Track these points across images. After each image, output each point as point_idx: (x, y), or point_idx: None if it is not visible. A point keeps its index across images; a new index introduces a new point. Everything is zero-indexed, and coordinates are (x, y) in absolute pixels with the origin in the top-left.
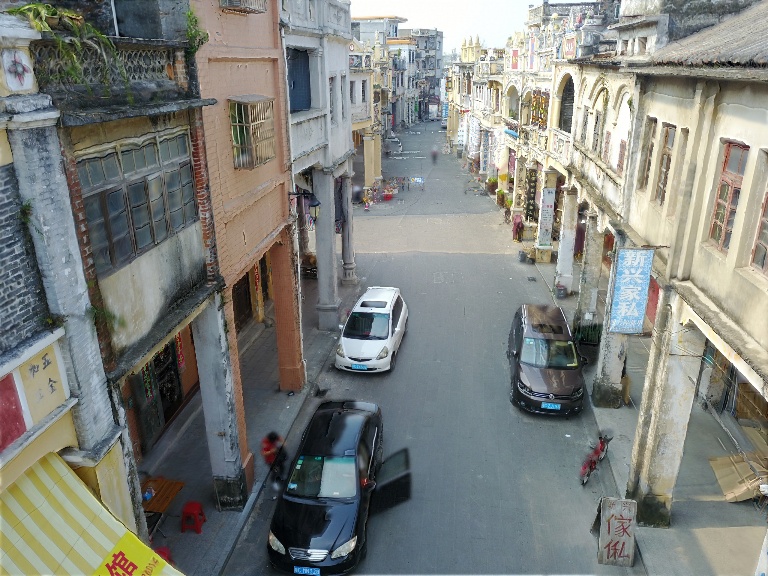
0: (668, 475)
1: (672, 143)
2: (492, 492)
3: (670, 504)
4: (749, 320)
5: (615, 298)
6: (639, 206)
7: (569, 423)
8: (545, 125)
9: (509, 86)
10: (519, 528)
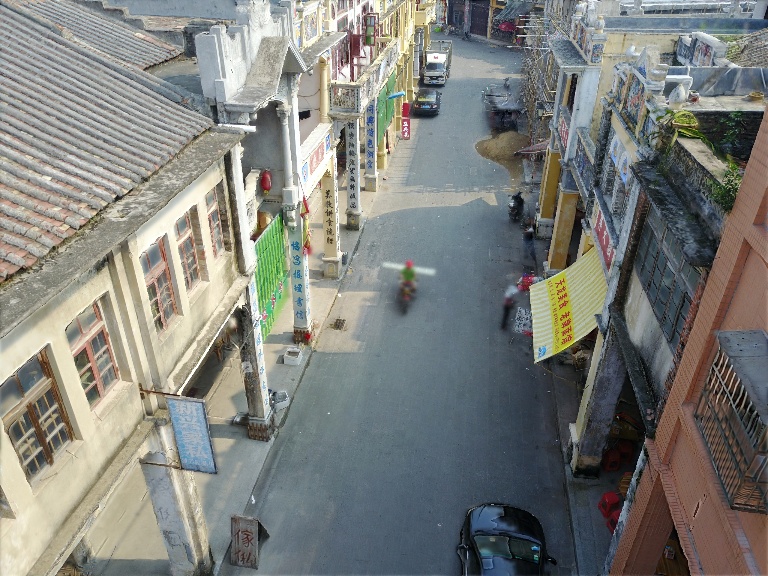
0: None
1: (22, 391)
2: None
3: None
4: None
5: None
6: (2, 558)
7: None
8: None
9: None
10: (322, 572)
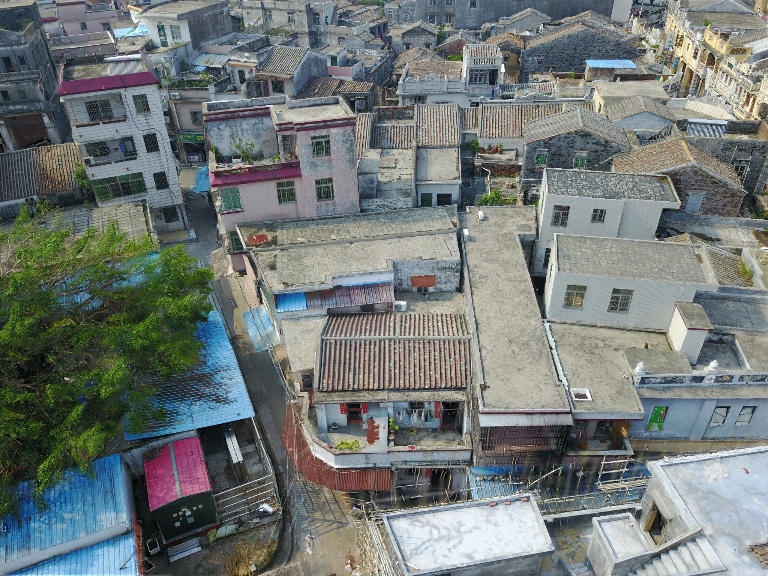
0: None
1: None
2: None
3: None
4: None
5: None
6: None
7: None
8: None
9: (764, 102)
10: None
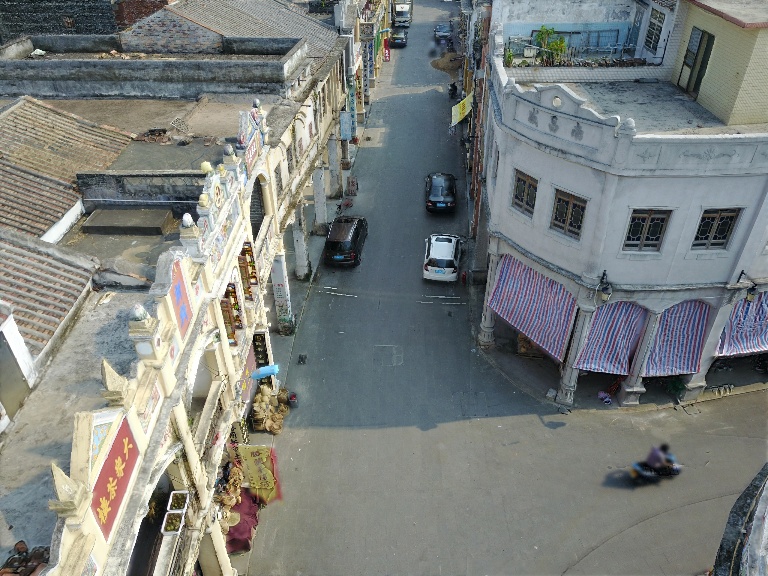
0: None
1: None
2: None
3: None
4: None
5: None
6: None
7: None
8: (254, 278)
9: None
10: None
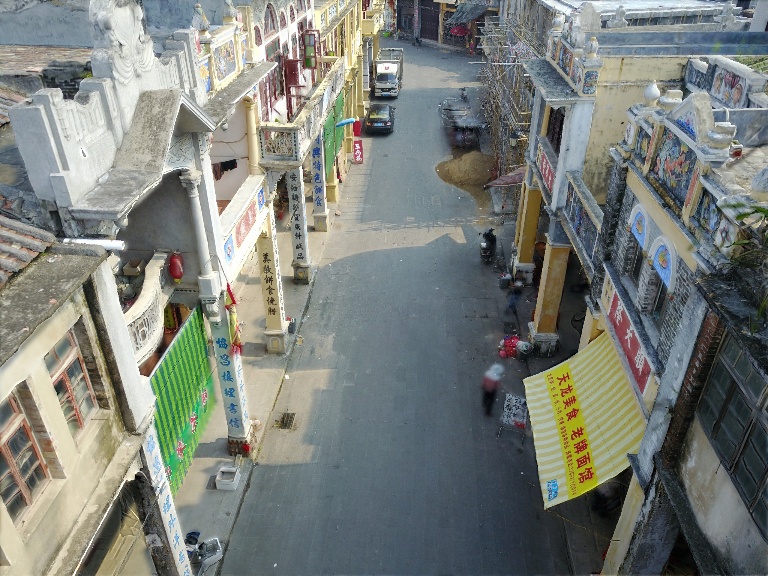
0: None
1: None
2: None
3: None
4: None
5: None
6: None
7: None
8: None
9: None
10: None
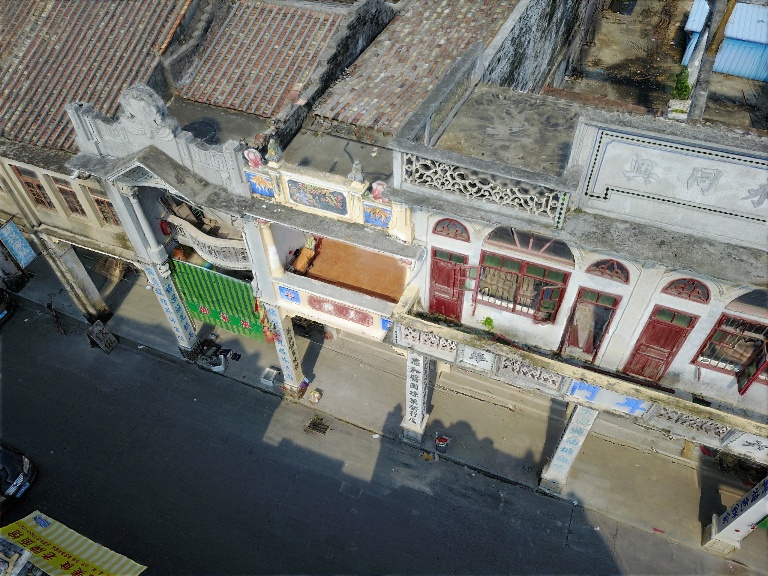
0: (97, 298)
1: None
2: (35, 379)
3: (107, 307)
4: (92, 236)
5: (14, 253)
6: None
7: (17, 314)
8: None
9: None
10: (67, 378)
